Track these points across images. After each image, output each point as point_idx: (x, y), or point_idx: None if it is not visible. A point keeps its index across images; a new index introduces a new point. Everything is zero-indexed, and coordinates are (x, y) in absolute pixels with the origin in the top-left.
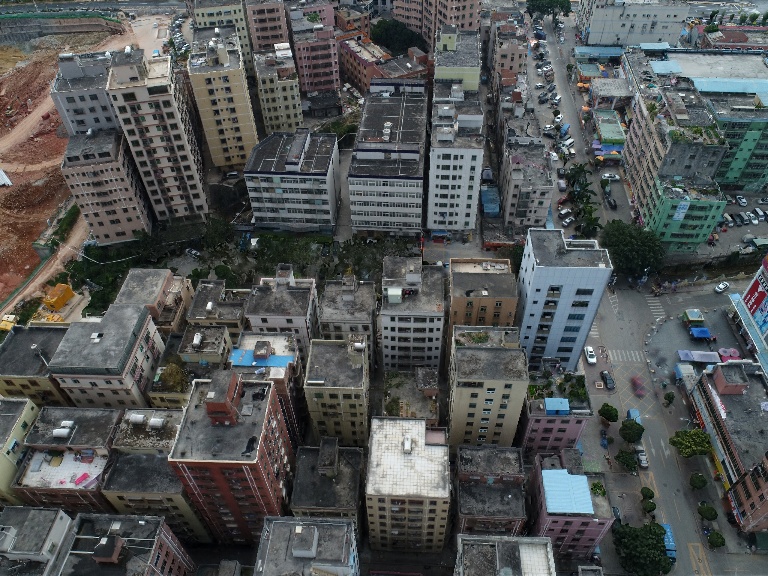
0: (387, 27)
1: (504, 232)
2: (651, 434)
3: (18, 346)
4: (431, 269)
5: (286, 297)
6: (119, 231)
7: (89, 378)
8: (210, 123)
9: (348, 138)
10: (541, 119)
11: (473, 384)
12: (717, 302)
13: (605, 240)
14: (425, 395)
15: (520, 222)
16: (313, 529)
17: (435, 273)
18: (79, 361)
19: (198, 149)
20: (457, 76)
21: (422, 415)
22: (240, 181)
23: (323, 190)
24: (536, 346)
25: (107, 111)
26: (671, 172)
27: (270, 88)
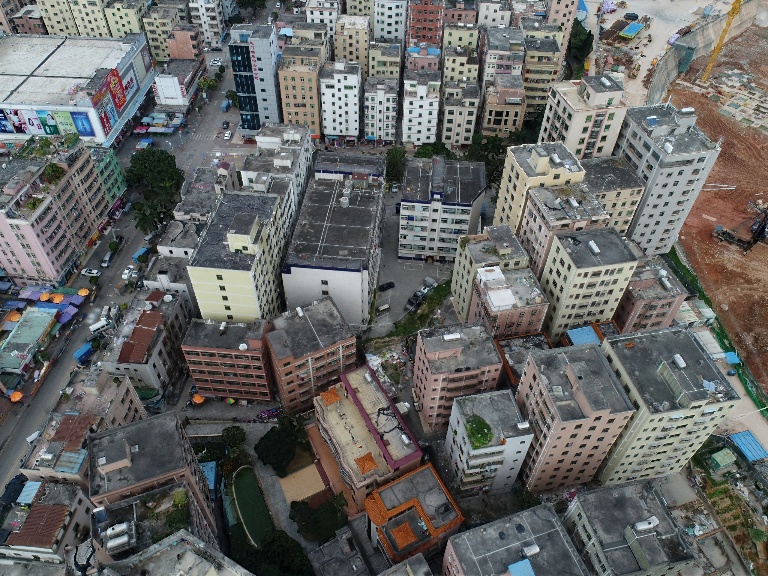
0: None
1: None
2: (219, 107)
3: None
4: (328, 81)
5: None
6: None
7: None
8: None
9: None
10: None
11: None
12: None
13: None
14: None
15: None
16: None
17: None
18: None
19: None
20: None
21: None
22: None
23: None
24: None
25: None
26: None
27: None
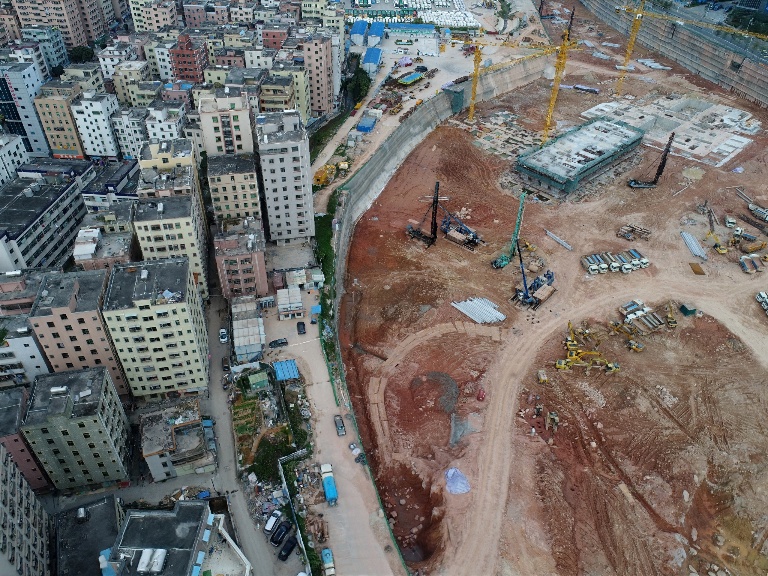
0: None
1: None
2: None
3: (285, 84)
4: (78, 108)
5: None
6: None
7: None
8: None
9: None
10: None
11: None
12: None
13: None
14: None
15: None
16: (166, 44)
17: None
18: None
19: None
20: None
21: None
22: None
23: None
24: None
25: None
26: None
27: None
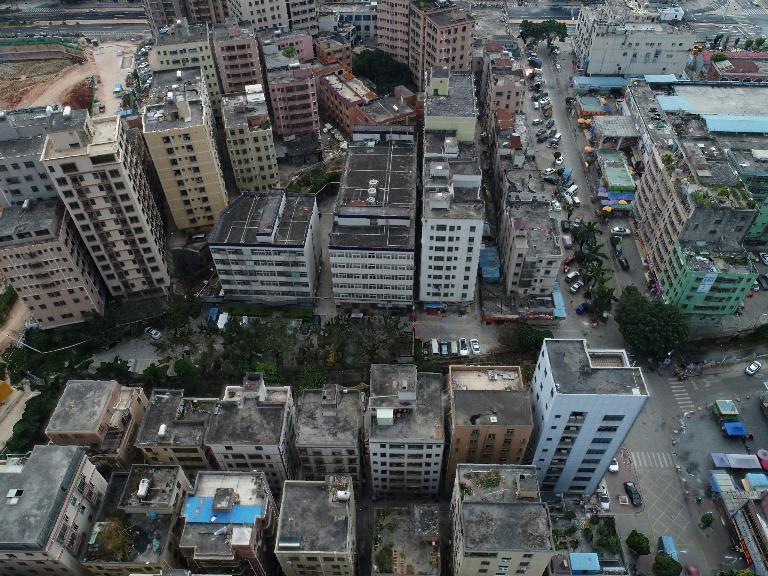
0: (371, 58)
1: (506, 303)
2: (688, 567)
3: None
4: (427, 377)
5: (255, 416)
6: (65, 313)
7: (3, 552)
8: (170, 184)
9: (329, 187)
10: (540, 161)
11: (484, 554)
12: (749, 387)
13: (621, 315)
14: (423, 540)
15: (524, 291)
16: None
17: (432, 382)
18: None
19: (158, 211)
20: (450, 126)
21: (420, 569)
22: (207, 245)
23: (300, 262)
24: (552, 467)
25: (46, 179)
26: (693, 237)
27: (240, 139)
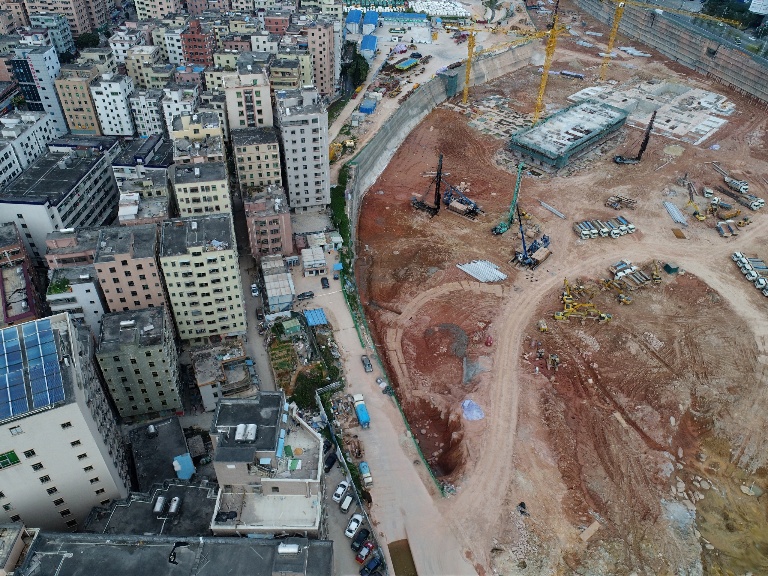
0: None
1: None
2: None
3: (293, 67)
4: (97, 89)
5: None
6: None
7: None
8: None
9: None
10: None
11: None
12: None
13: None
14: None
15: None
16: (175, 29)
17: None
18: (258, 52)
19: None
20: None
21: None
22: None
23: None
24: None
25: None
26: None
27: None
